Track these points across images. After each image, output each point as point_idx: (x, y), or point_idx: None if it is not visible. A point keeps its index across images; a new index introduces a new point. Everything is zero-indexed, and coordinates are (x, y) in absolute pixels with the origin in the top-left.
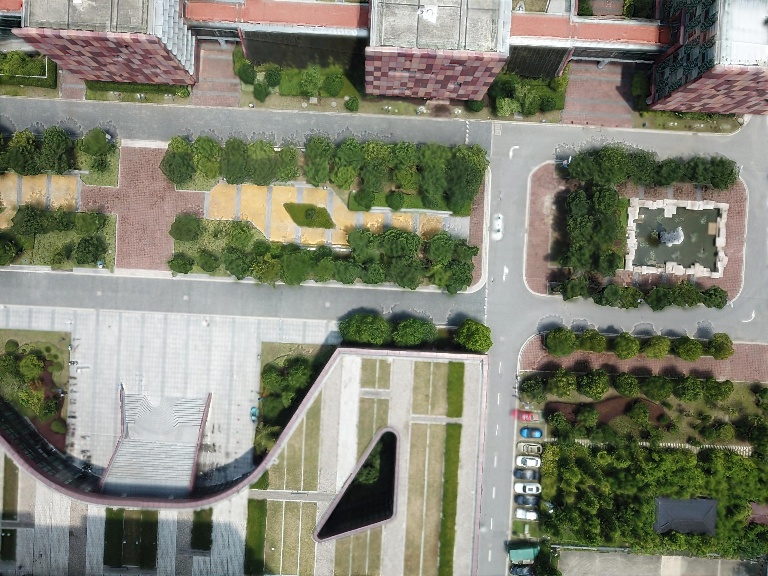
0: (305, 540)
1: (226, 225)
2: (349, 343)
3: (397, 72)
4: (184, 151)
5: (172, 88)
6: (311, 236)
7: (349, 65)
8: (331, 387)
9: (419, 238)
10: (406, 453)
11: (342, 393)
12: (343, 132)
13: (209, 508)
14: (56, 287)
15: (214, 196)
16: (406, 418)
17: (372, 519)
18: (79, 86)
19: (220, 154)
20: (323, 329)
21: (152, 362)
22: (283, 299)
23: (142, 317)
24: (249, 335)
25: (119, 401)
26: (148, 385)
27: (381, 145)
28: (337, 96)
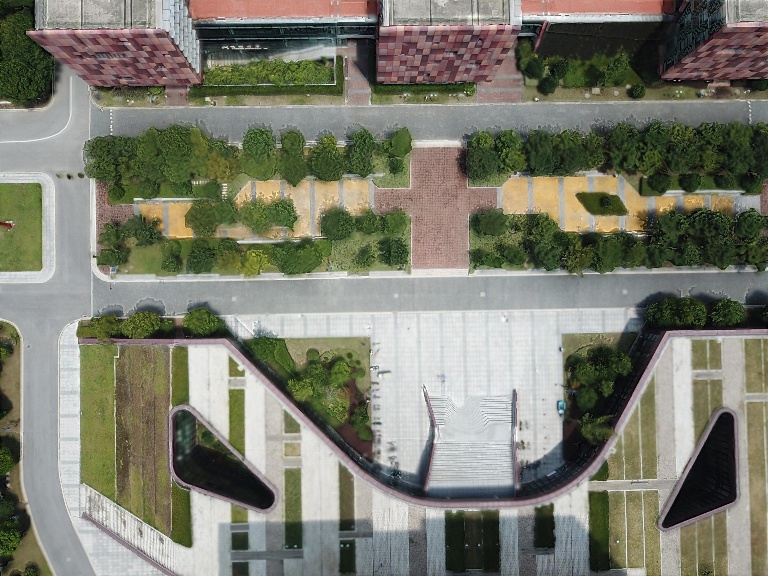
0: (649, 530)
1: (520, 219)
2: (663, 327)
3: (724, 51)
4: (488, 146)
5: (460, 87)
6: (605, 224)
7: (635, 53)
8: (663, 371)
9: (728, 217)
10: (744, 433)
11: (674, 376)
12: (627, 120)
13: (550, 504)
14: (352, 292)
15: (506, 191)
16: (740, 397)
17: (709, 504)
18: (364, 92)
19: (521, 147)
20: (622, 317)
21: (453, 362)
22: (580, 289)
23: (440, 317)
24: (548, 328)
25: (423, 404)
26: (451, 385)
27: (684, 128)
28: (620, 85)
